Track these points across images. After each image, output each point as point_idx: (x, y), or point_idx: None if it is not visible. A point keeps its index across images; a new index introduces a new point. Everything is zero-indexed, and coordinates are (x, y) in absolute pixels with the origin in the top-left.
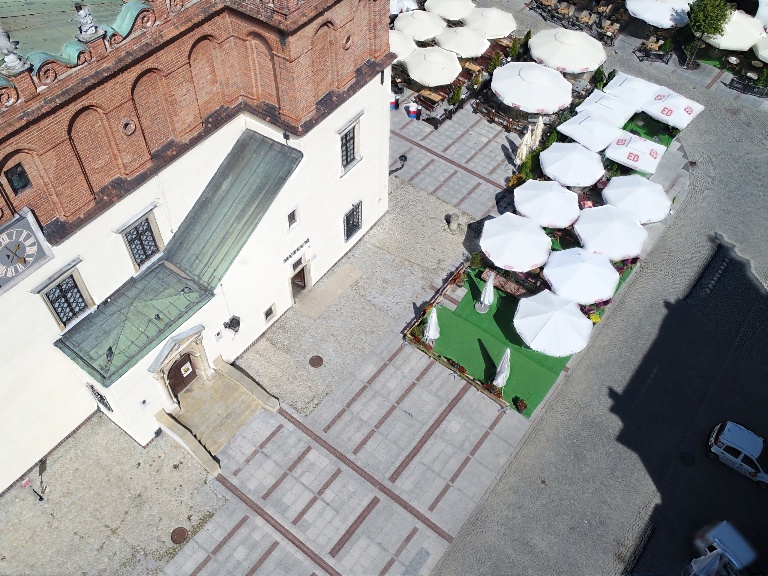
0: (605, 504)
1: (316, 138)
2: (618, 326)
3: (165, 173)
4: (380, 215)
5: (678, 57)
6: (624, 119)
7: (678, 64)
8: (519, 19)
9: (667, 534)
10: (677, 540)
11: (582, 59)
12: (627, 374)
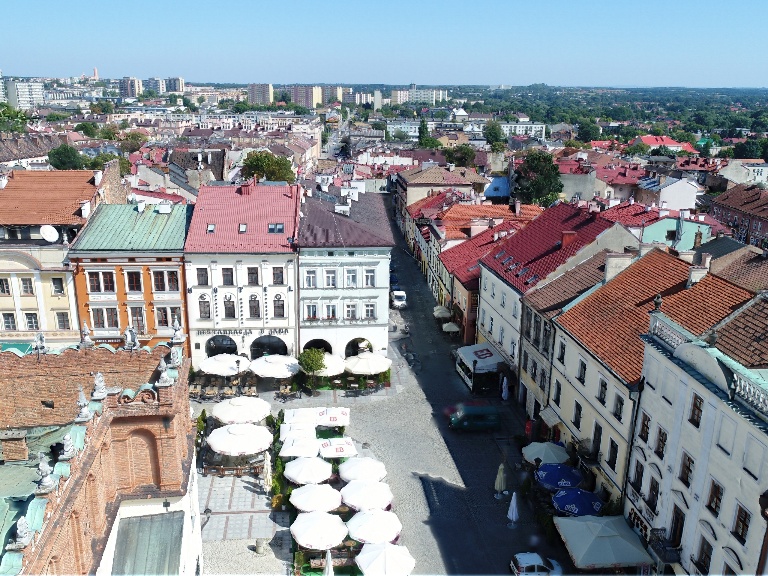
0: None
1: (184, 498)
2: (413, 549)
3: (97, 569)
4: (202, 571)
5: (304, 392)
6: (314, 433)
7: (307, 396)
8: None
9: None
10: None
11: (259, 410)
12: (443, 572)
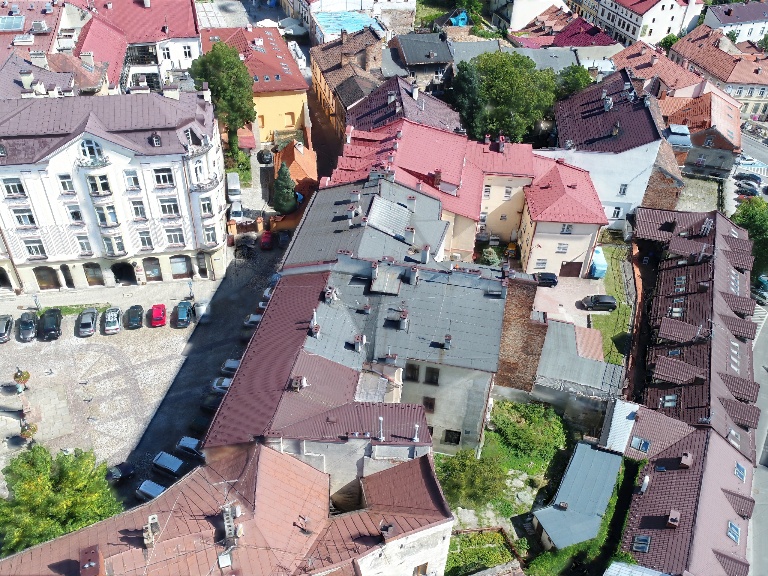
0: (234, 3)
1: None
2: None
3: None
4: None
5: None
6: None
7: None
8: None
9: (244, 2)
10: (246, 2)
11: None
12: None
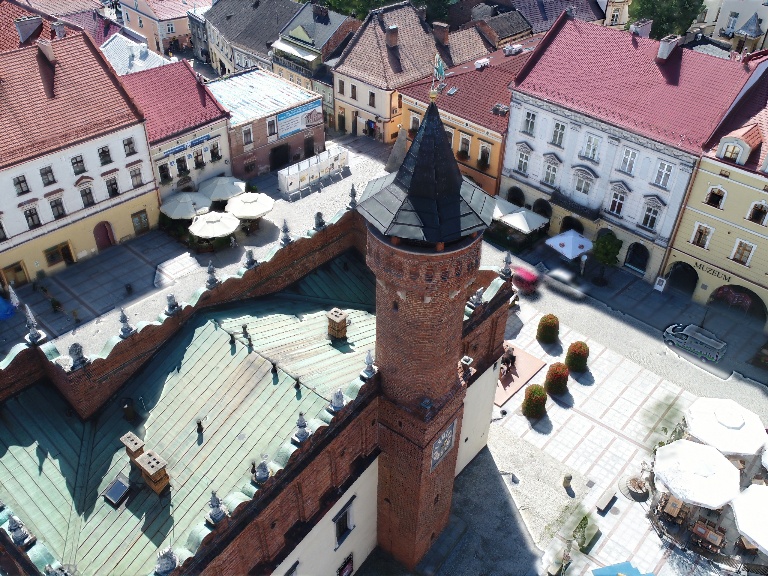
0: None
1: None
2: None
3: None
4: None
5: None
6: None
7: None
8: None
9: None
10: None
11: None
12: None
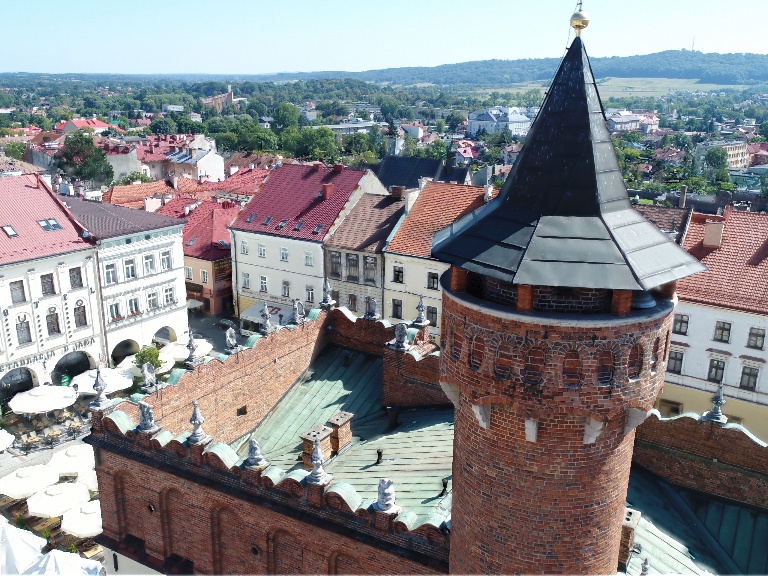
0: None
1: None
2: None
3: None
4: None
5: None
6: None
7: None
8: (39, 463)
9: None
10: None
11: None
12: None
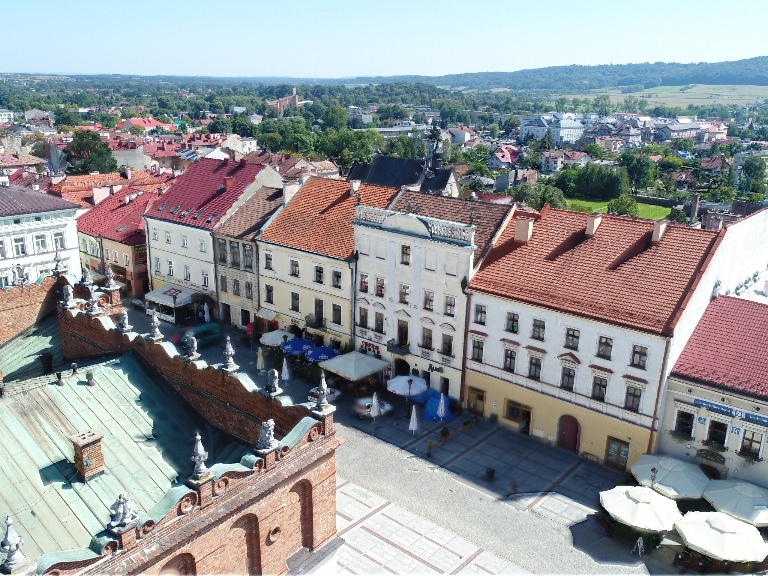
0: None
1: None
2: None
3: None
4: None
5: None
6: None
7: None
8: None
9: (356, 424)
10: None
11: None
12: None
